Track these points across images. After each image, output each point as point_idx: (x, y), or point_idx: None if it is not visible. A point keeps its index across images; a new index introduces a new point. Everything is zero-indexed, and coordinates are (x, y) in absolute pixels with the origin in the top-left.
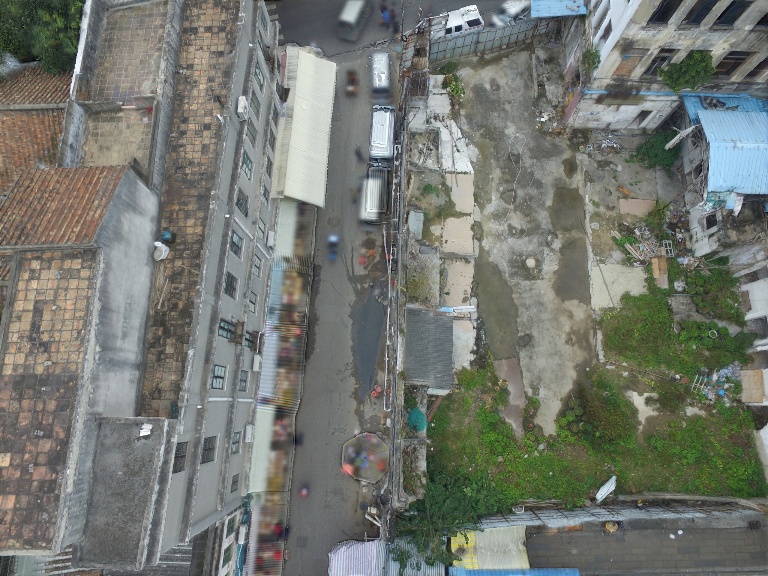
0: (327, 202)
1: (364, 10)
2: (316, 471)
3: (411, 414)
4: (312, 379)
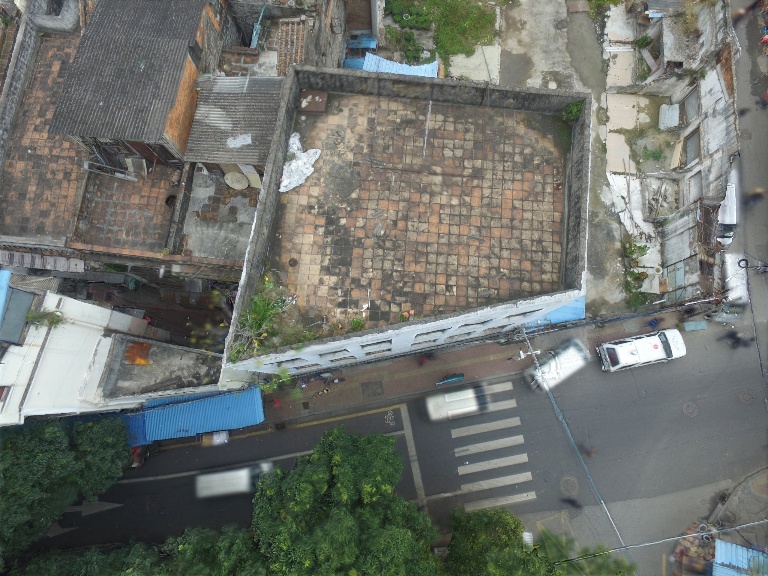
0: (756, 155)
1: (750, 401)
2: None
3: None
4: (744, 5)
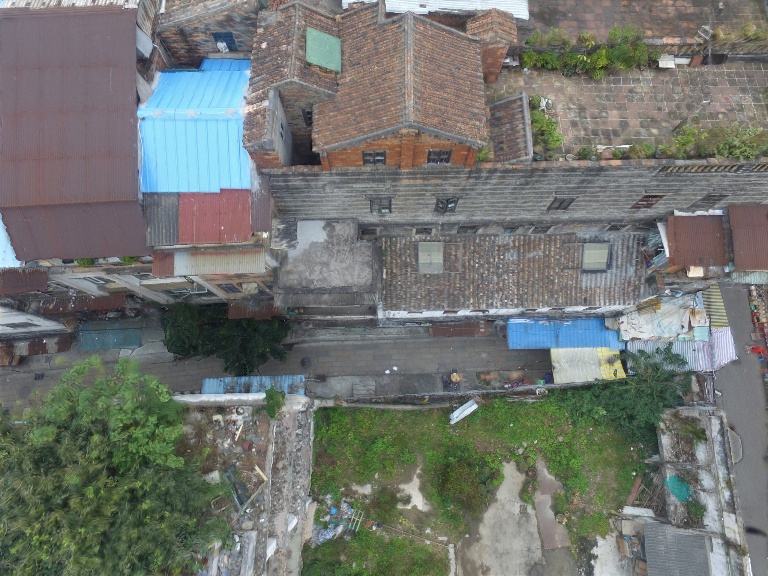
0: None
1: None
2: (738, 424)
3: (688, 494)
4: (767, 523)
